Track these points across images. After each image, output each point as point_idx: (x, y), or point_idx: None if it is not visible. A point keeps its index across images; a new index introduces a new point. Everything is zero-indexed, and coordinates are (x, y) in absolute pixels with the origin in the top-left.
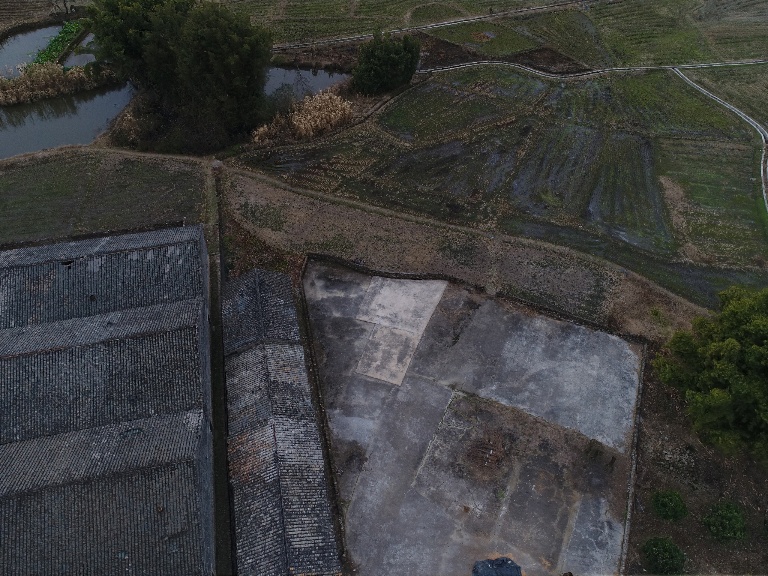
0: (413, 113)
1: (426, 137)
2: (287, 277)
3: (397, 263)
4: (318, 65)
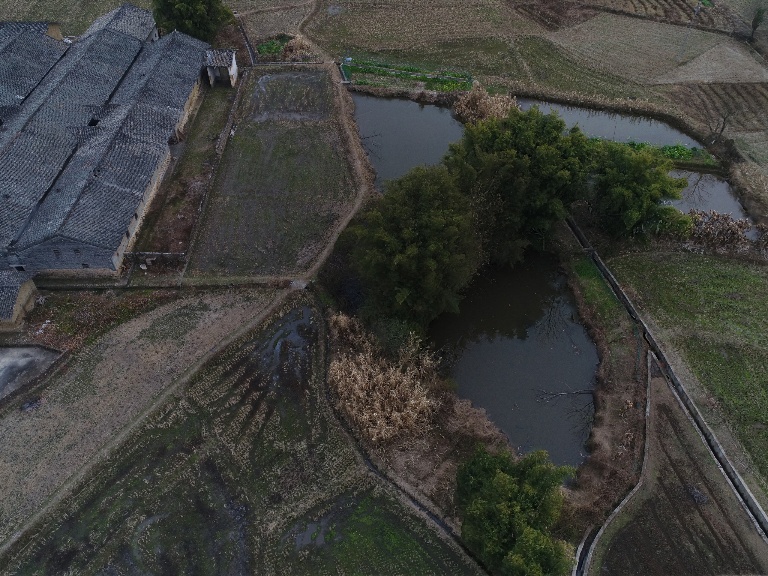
0: (387, 568)
1: (286, 569)
2: (6, 315)
3: (0, 447)
4: (598, 421)
